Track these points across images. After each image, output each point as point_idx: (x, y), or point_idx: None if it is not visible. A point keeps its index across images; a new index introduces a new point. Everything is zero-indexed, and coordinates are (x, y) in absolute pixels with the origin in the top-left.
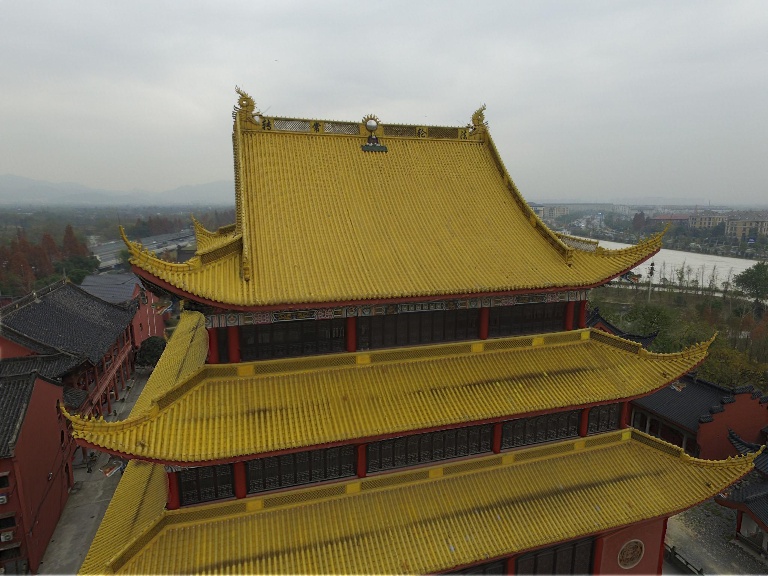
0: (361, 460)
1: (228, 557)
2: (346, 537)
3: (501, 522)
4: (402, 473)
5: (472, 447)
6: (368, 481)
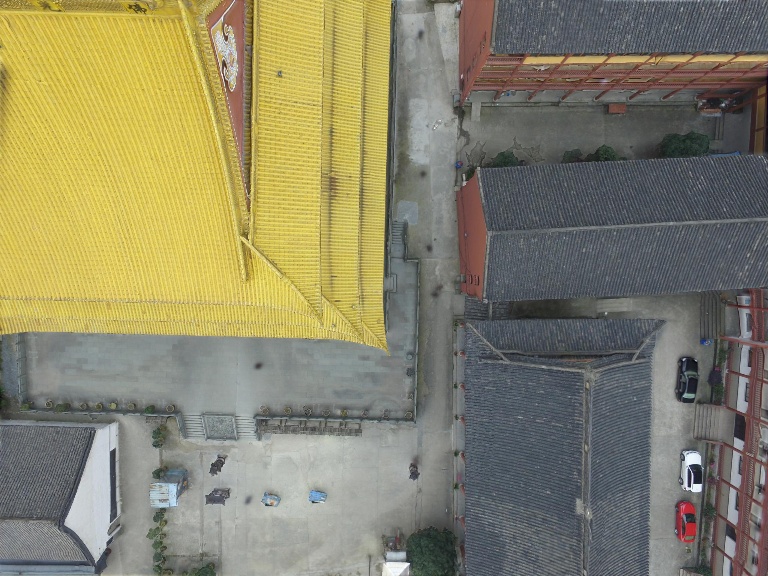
0: None
1: None
2: None
3: None
4: None
5: None
6: None
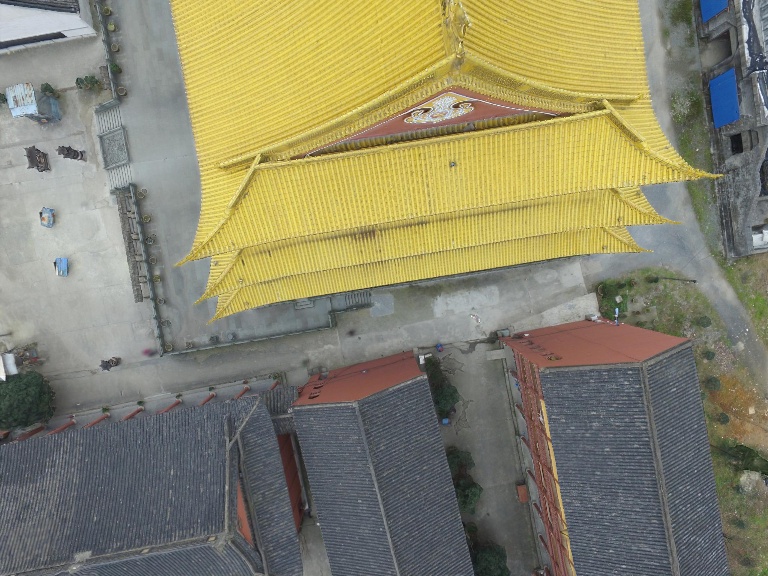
0: None
1: None
2: None
3: None
4: None
5: None
6: None
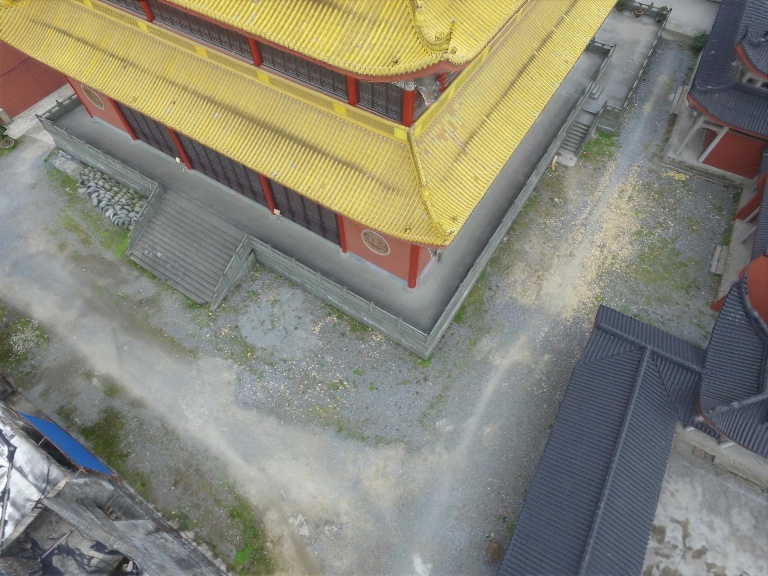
0: (142, 2)
1: (66, 29)
2: (123, 59)
3: (213, 119)
4: (173, 34)
5: (234, 45)
6: (150, 26)
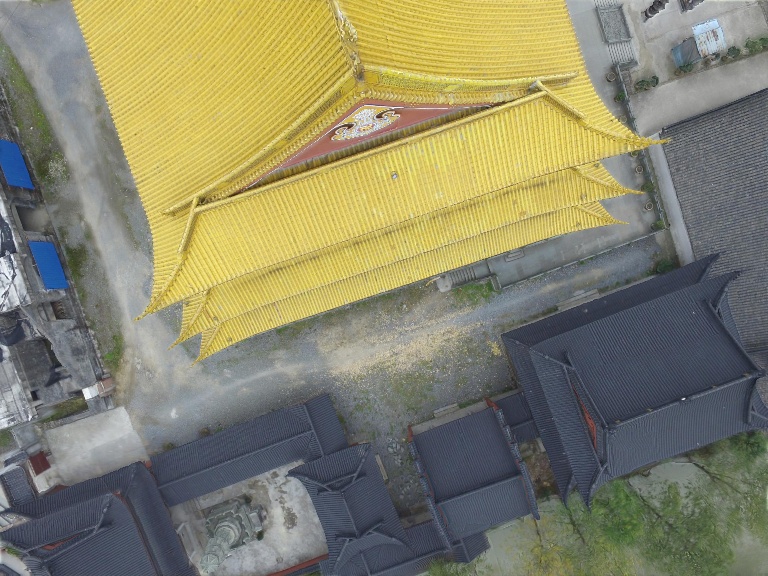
0: None
1: None
2: None
3: None
4: None
5: None
6: None
